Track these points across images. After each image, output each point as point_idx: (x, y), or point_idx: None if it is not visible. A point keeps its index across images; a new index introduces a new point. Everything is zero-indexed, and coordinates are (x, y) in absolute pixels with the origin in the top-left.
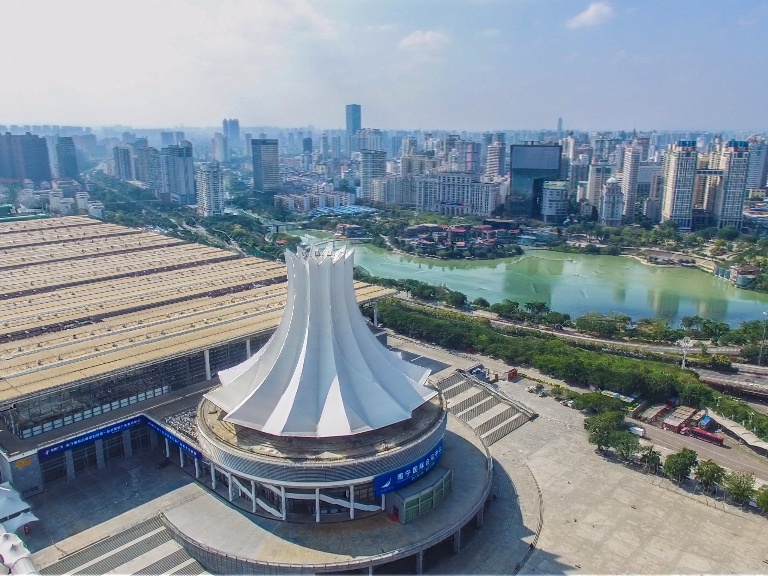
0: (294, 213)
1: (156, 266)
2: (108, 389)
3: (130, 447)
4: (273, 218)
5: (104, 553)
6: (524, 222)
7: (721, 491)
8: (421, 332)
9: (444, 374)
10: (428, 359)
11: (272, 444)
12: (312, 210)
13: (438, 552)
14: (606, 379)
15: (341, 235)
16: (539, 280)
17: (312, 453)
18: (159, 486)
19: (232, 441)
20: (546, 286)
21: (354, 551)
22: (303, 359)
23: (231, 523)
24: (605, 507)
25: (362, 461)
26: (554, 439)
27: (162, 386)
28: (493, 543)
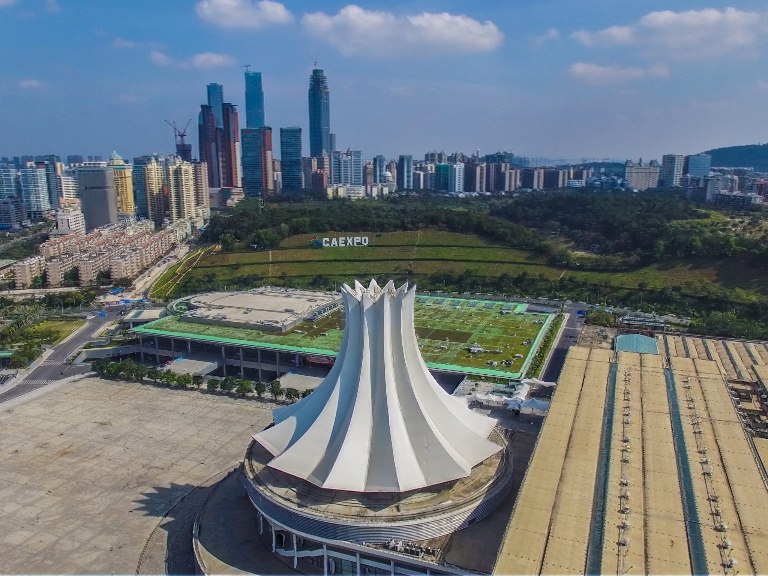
0: None
1: None
2: None
3: None
4: None
5: None
6: None
7: None
8: None
9: None
10: None
11: None
12: None
13: None
14: None
15: None
16: None
17: None
18: None
19: None
20: None
21: None
22: None
23: None
24: (67, 573)
25: None
26: None
27: None
28: None
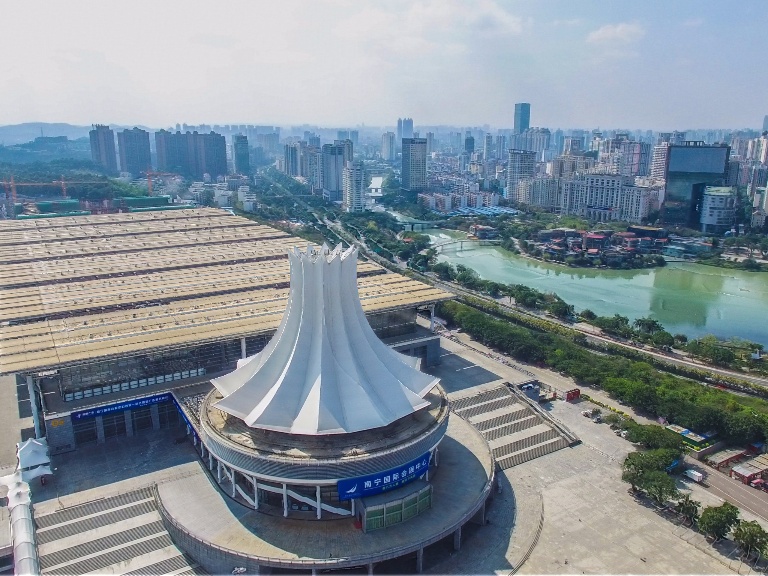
0: (434, 212)
1: (248, 257)
2: (145, 365)
3: (158, 421)
4: (413, 216)
5: (94, 512)
6: (675, 231)
7: (764, 560)
8: (493, 340)
9: (490, 386)
10: (481, 369)
11: (251, 434)
12: (453, 210)
13: (400, 568)
14: (676, 412)
15: (473, 236)
16: (672, 295)
17: (282, 448)
18: (167, 460)
19: (218, 426)
20: (678, 302)
21: (303, 551)
22: (292, 355)
23: (208, 504)
24: (609, 554)
25: (325, 463)
26: (587, 470)
27: (198, 368)
28: (462, 570)
